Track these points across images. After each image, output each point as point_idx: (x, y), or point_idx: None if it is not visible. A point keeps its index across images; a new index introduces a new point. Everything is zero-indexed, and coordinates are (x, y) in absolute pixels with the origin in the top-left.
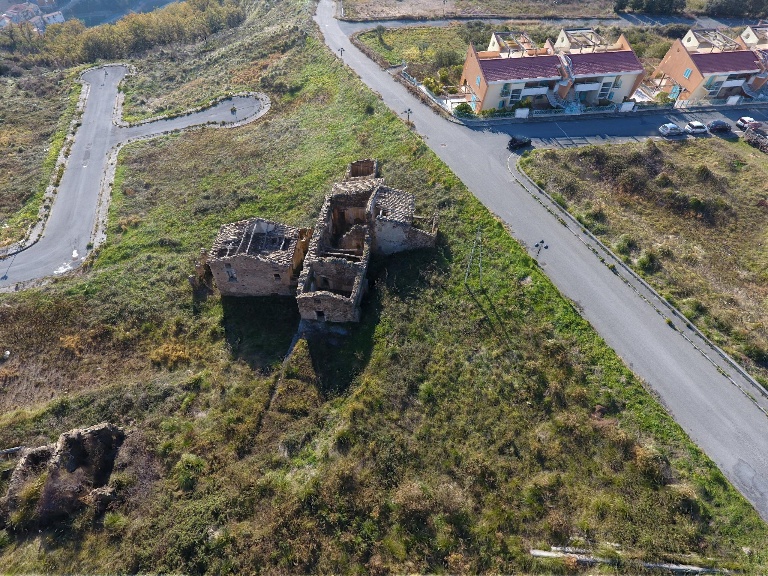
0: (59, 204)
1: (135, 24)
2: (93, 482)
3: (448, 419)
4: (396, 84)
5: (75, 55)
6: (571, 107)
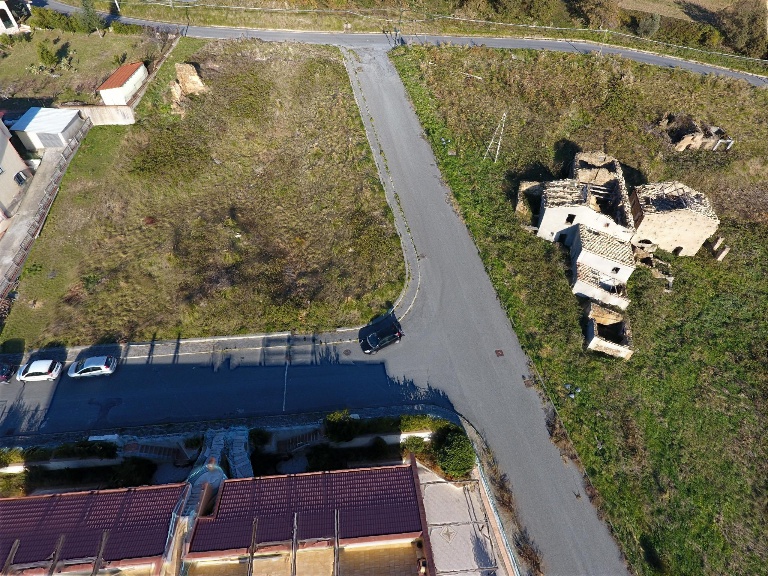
0: None
1: None
2: None
3: None
4: None
5: None
6: (238, 429)
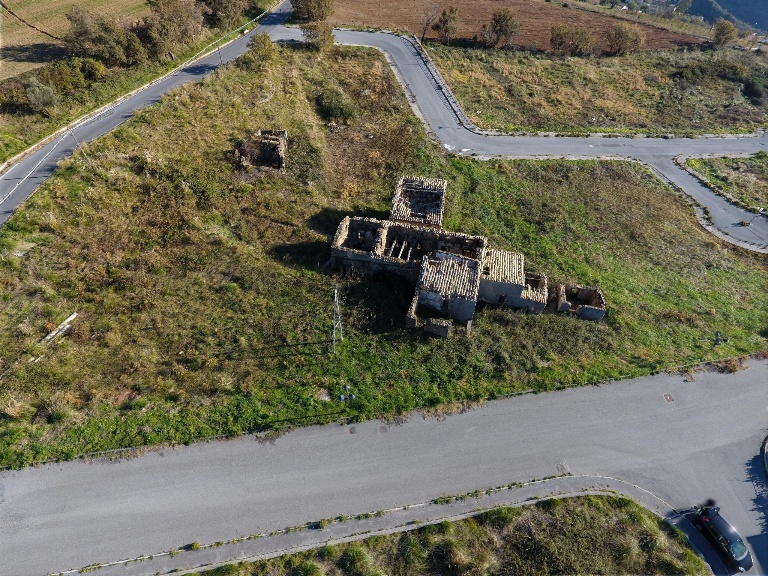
0: (530, 139)
1: None
2: (258, 164)
3: (200, 297)
4: None
5: None
6: None
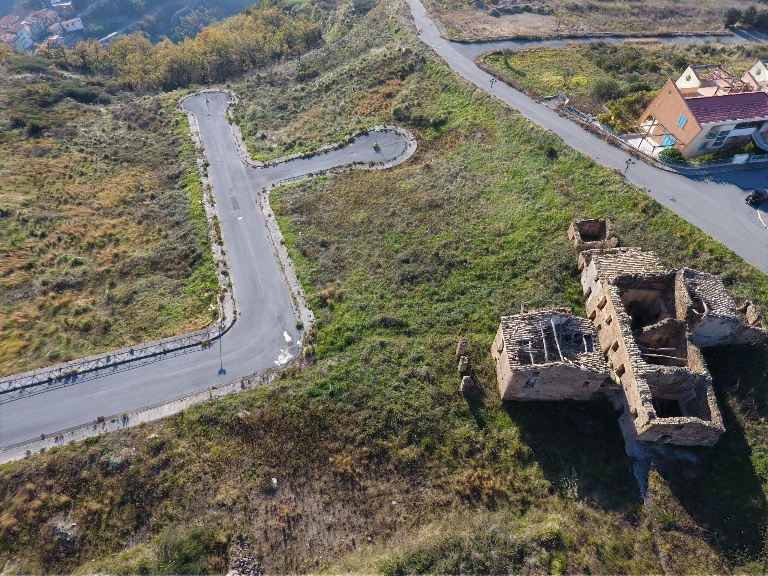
0: (236, 269)
1: (218, 44)
2: None
3: None
4: (564, 120)
5: (155, 77)
6: None
